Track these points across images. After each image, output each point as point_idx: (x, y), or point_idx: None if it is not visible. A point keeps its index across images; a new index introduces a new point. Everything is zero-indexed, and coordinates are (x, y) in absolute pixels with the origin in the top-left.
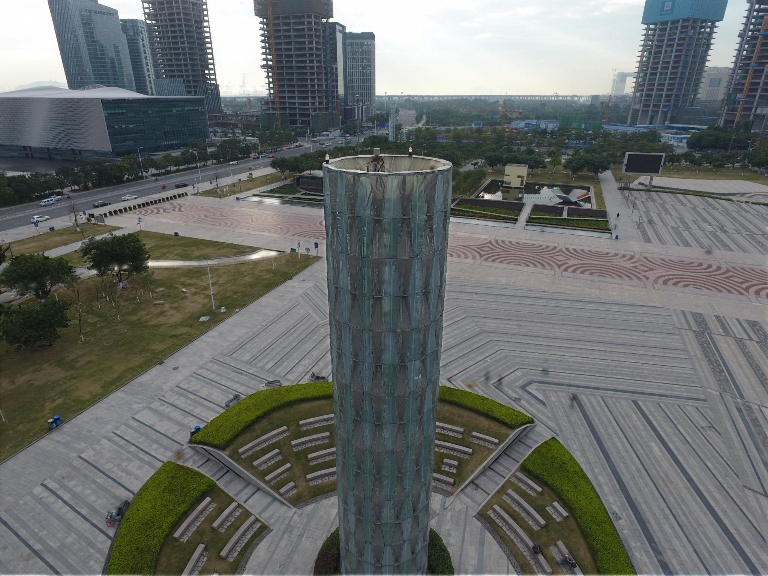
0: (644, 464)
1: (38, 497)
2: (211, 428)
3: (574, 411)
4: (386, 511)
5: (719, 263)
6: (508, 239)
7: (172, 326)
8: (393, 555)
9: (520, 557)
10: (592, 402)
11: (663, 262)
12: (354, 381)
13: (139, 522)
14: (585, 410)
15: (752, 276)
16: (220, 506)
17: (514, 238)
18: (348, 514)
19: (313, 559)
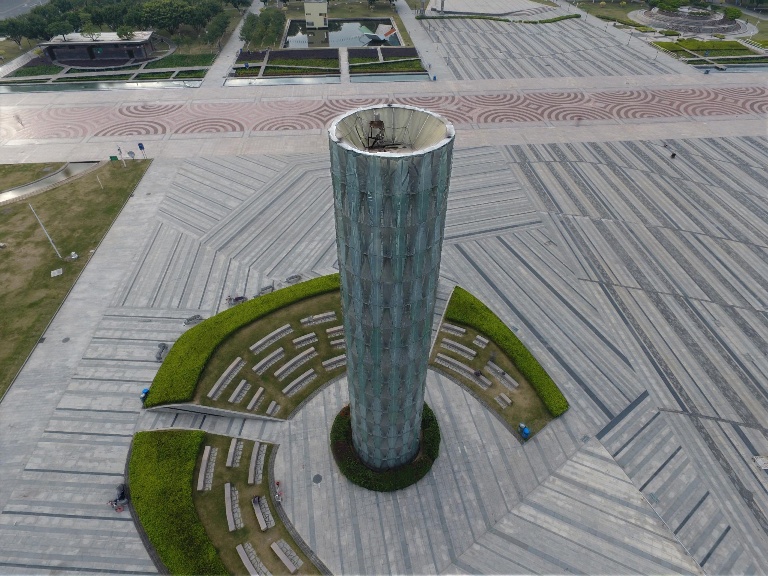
0: (519, 285)
1: (12, 525)
2: (162, 386)
3: (461, 259)
4: (406, 400)
5: (518, 92)
6: (341, 97)
7: (20, 294)
8: (410, 425)
9: (468, 382)
10: (471, 247)
11: (478, 99)
12: (384, 323)
13: (154, 495)
14: (468, 255)
15: (542, 101)
16: (222, 448)
17: (346, 95)
18: (373, 413)
19: (327, 450)
